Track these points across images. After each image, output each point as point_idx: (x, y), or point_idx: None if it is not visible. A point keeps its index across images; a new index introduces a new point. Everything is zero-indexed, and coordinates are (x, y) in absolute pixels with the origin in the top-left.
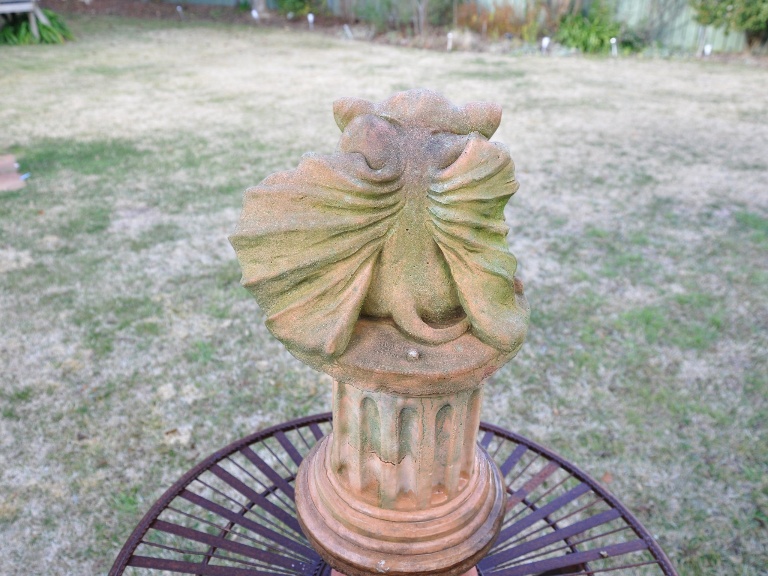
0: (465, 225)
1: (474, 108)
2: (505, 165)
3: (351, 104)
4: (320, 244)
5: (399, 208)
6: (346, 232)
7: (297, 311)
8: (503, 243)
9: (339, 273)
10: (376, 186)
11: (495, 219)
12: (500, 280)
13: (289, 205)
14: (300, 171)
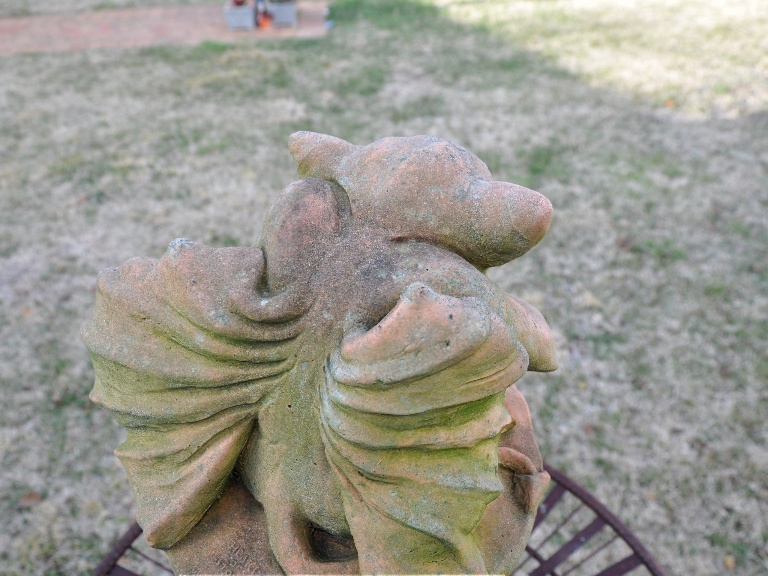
0: (357, 445)
1: (494, 202)
2: (461, 358)
3: (308, 151)
4: (157, 393)
5: (283, 370)
6: (194, 386)
7: (135, 462)
8: (468, 457)
9: (181, 439)
10: (252, 327)
11: (448, 425)
12: (420, 534)
13: (128, 323)
14: (155, 273)
